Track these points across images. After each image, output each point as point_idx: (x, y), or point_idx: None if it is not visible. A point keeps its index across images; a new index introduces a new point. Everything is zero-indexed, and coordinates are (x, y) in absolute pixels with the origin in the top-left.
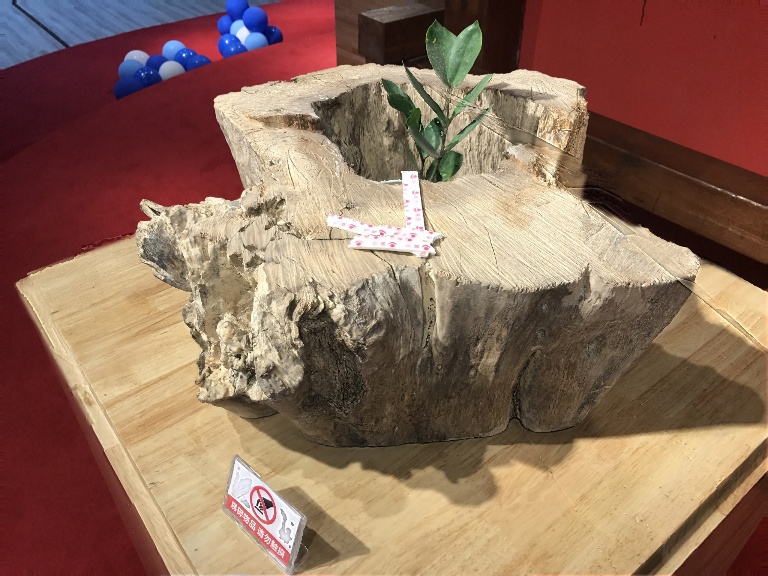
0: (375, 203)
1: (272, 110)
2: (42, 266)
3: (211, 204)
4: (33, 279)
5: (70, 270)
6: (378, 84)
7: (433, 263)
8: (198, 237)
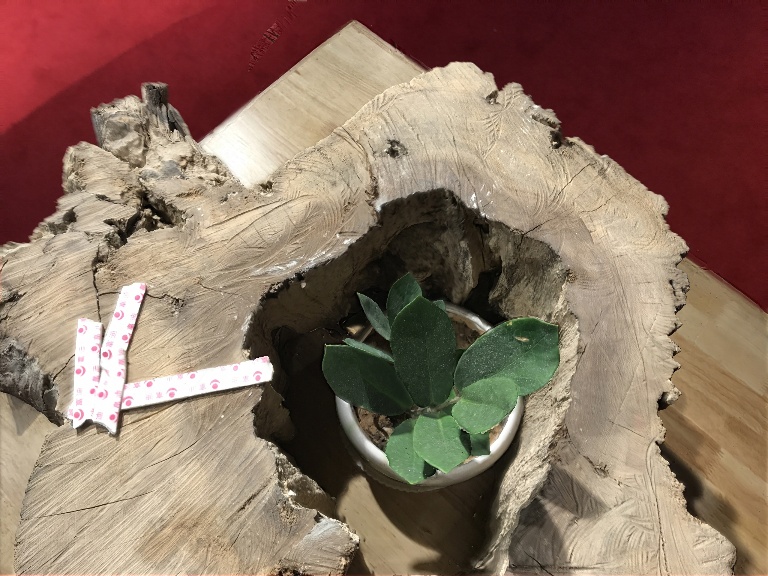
0: (189, 334)
1: (399, 143)
2: (377, 28)
3: (157, 149)
4: (347, 32)
5: (359, 55)
6: (566, 272)
7: (62, 428)
8: (77, 159)
